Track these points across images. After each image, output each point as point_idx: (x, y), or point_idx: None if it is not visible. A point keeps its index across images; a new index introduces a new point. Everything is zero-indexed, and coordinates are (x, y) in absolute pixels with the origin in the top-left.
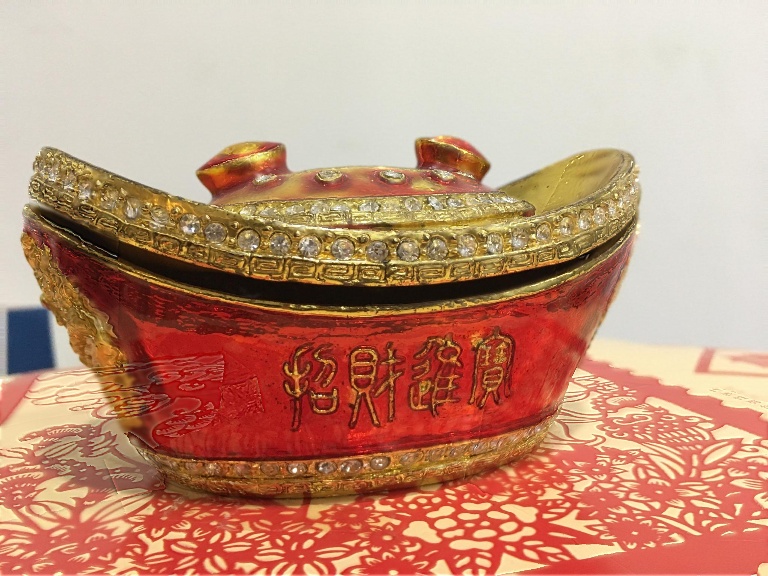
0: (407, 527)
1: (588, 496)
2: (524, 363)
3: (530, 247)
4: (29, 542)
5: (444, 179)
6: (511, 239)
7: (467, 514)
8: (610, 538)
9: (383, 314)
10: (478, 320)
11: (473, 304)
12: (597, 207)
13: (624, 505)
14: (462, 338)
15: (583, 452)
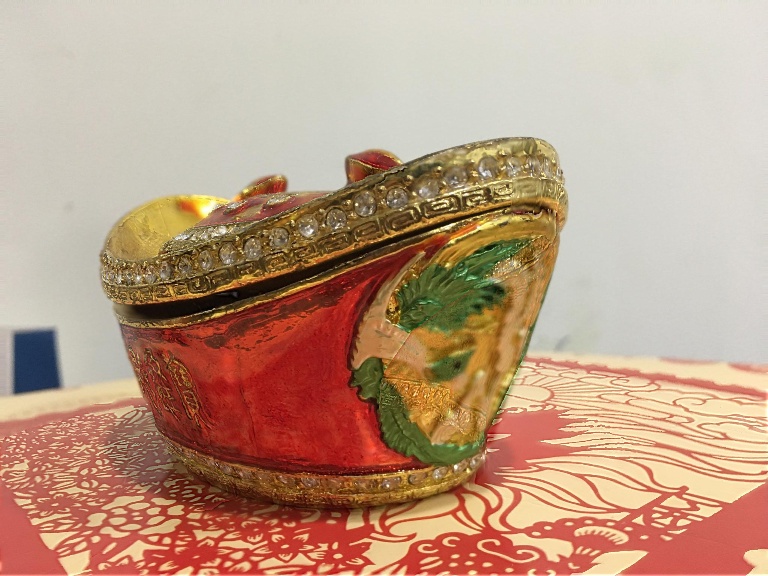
0: (132, 496)
1: (204, 550)
2: (214, 395)
3: (172, 279)
4: (116, 425)
5: (265, 206)
6: (158, 271)
7: (158, 509)
8: (99, 567)
9: (125, 323)
10: (160, 342)
11: (152, 326)
12: (252, 238)
13: (180, 568)
14: (158, 355)
15: (343, 535)
